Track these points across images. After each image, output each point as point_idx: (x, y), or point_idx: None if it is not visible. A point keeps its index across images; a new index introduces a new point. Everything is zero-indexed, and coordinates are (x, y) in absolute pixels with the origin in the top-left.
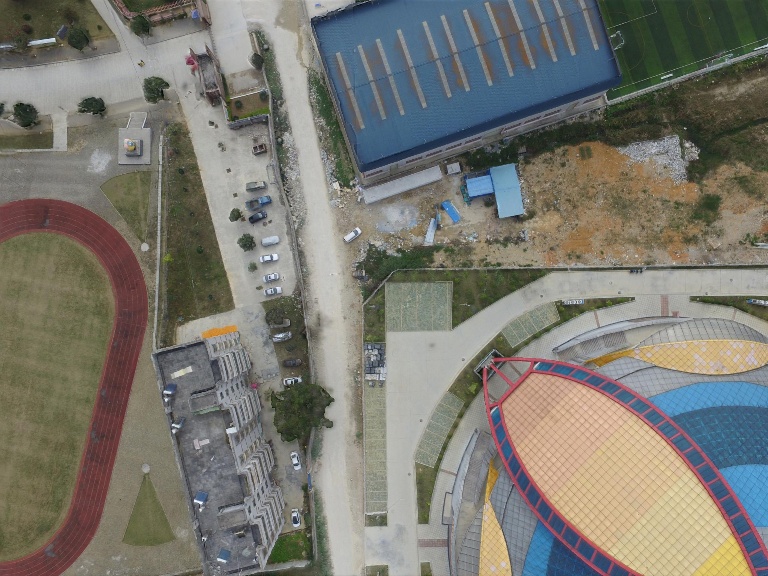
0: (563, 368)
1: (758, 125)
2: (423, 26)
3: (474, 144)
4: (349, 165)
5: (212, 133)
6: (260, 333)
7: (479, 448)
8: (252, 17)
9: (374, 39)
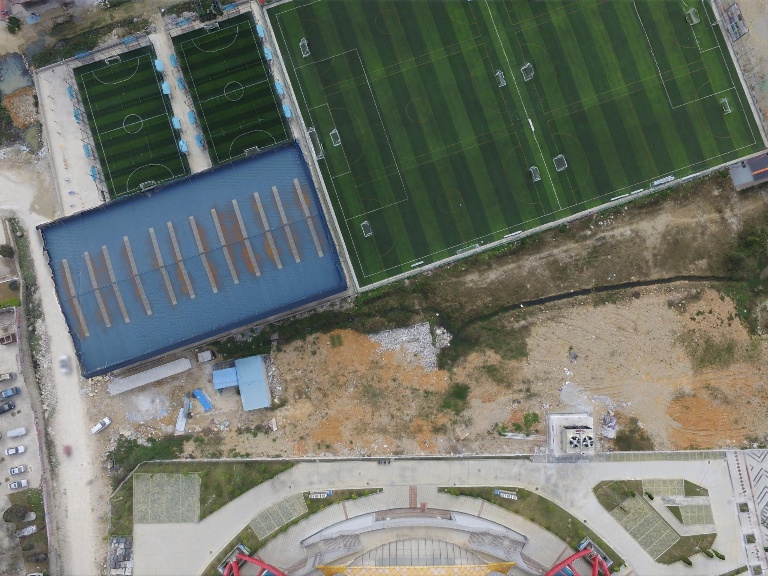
0: None
1: (509, 311)
2: (149, 233)
3: (225, 332)
4: None
5: None
6: (5, 526)
7: None
8: (6, 204)
9: (101, 245)
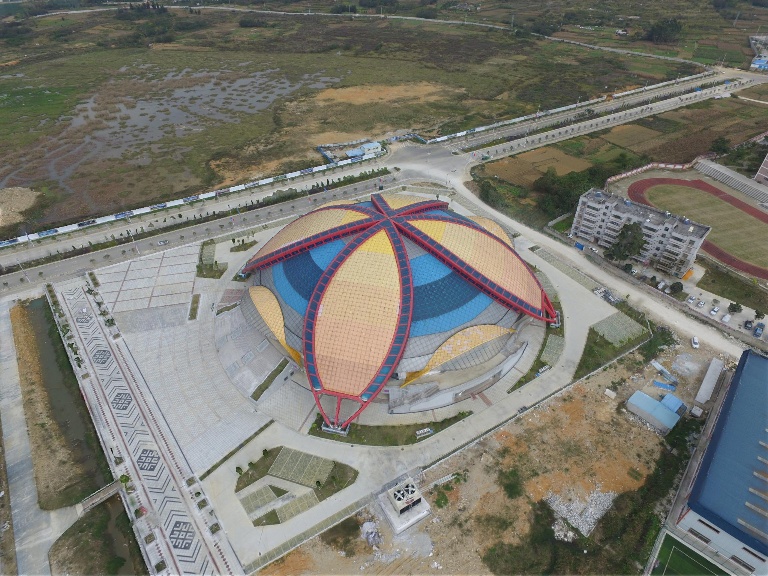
0: None
1: None
2: None
3: (707, 434)
4: None
5: None
6: (671, 283)
7: None
8: None
9: None
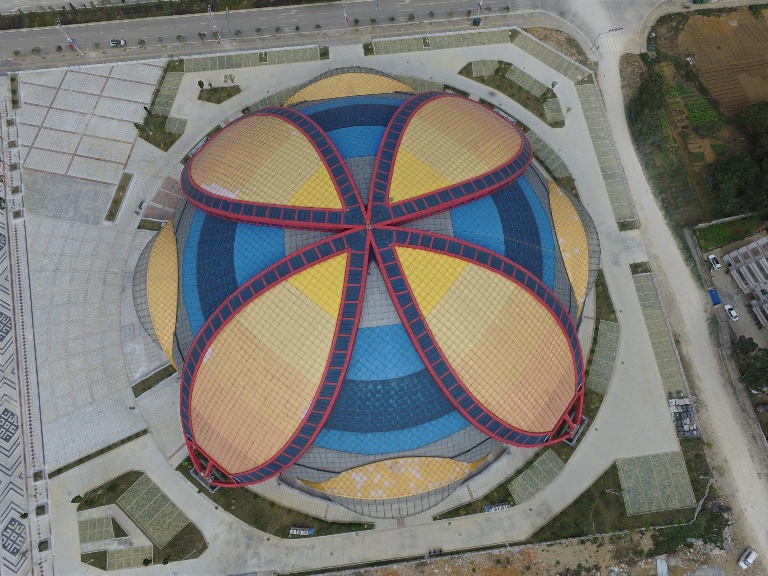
0: (532, 442)
1: None
2: None
3: None
4: None
5: None
6: None
7: None
8: None
9: None
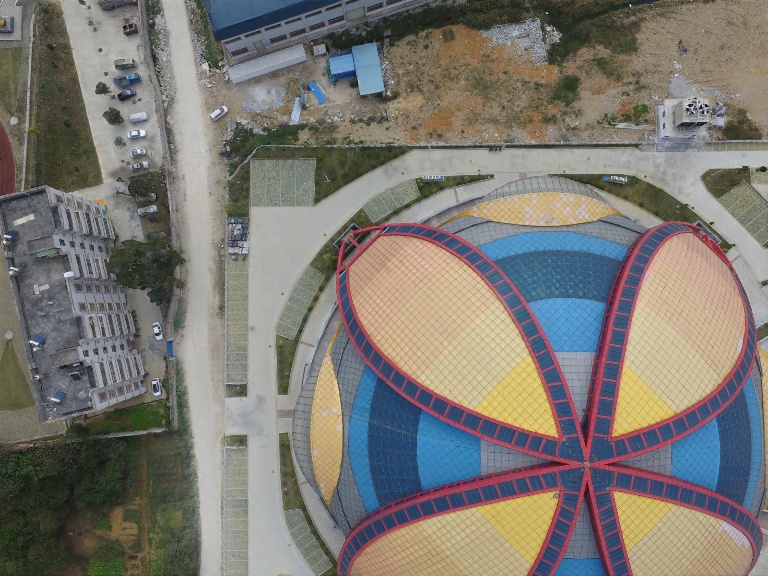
0: (405, 228)
1: (618, 10)
2: None
3: (340, 26)
4: (218, 46)
5: (85, 14)
6: (127, 207)
7: (337, 319)
8: None
9: None
